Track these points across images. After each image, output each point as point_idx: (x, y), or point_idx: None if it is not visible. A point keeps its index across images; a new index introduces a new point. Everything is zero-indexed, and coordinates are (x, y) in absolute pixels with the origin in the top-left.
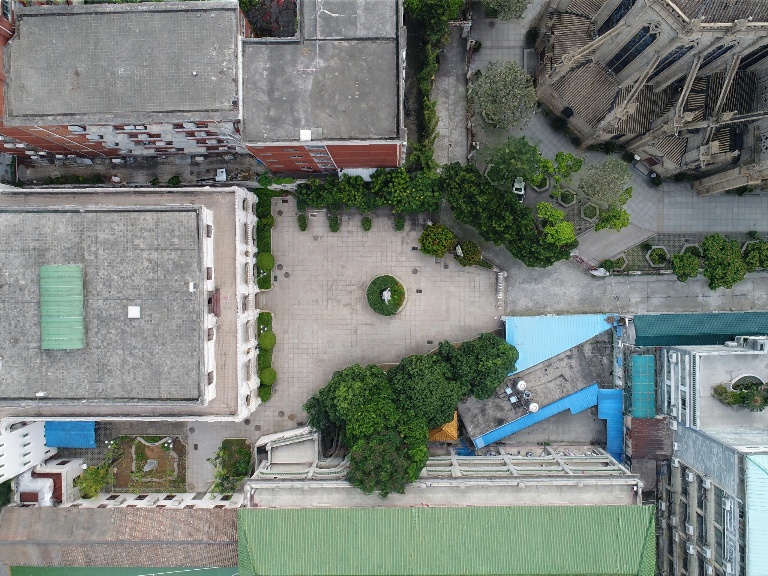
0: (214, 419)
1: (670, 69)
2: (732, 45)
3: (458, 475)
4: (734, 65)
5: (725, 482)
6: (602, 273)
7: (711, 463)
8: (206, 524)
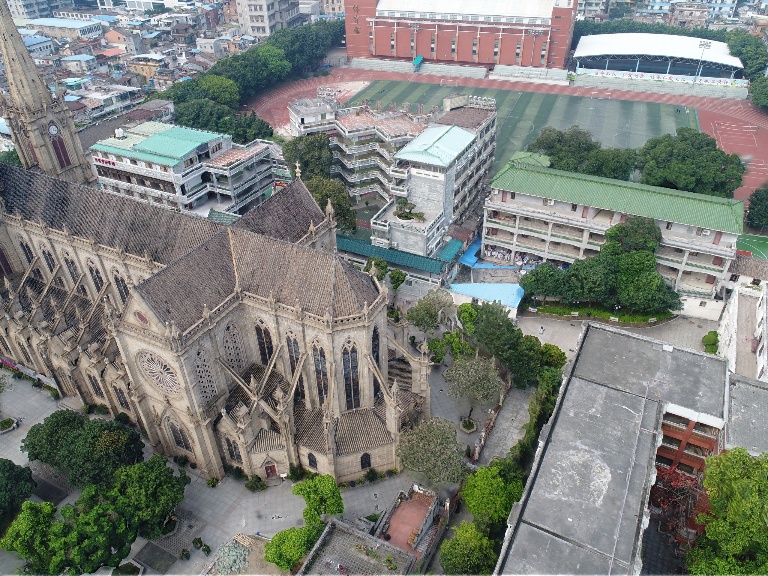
0: (758, 291)
1: None
2: None
3: (586, 233)
4: None
5: None
6: None
7: None
8: (766, 271)
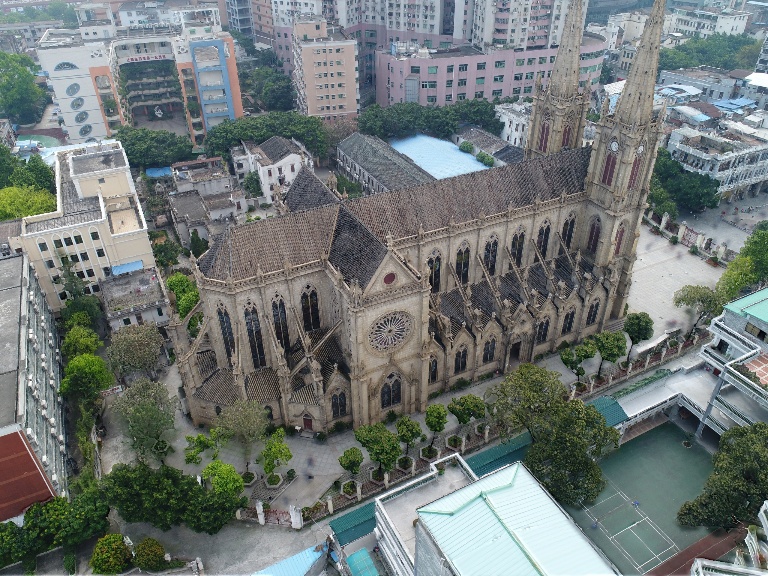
0: None
1: (264, 341)
2: (282, 302)
3: None
4: (295, 315)
5: (438, 570)
6: (292, 510)
7: (430, 575)
8: None
